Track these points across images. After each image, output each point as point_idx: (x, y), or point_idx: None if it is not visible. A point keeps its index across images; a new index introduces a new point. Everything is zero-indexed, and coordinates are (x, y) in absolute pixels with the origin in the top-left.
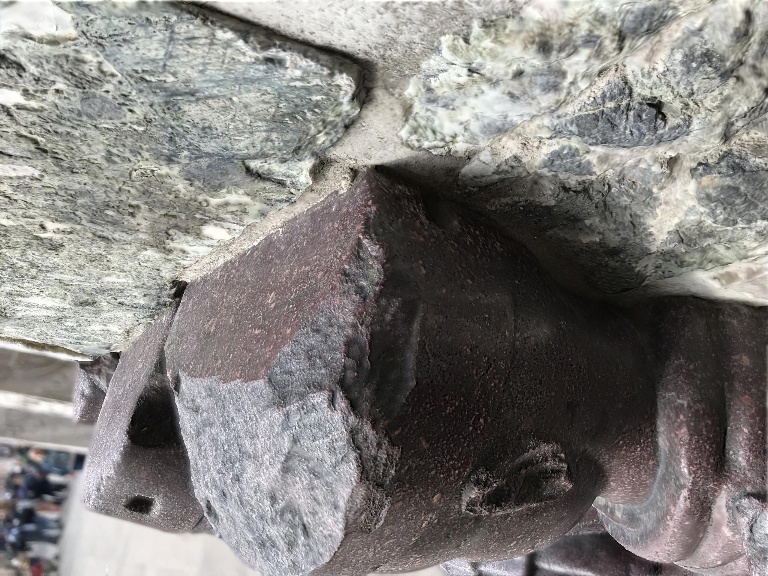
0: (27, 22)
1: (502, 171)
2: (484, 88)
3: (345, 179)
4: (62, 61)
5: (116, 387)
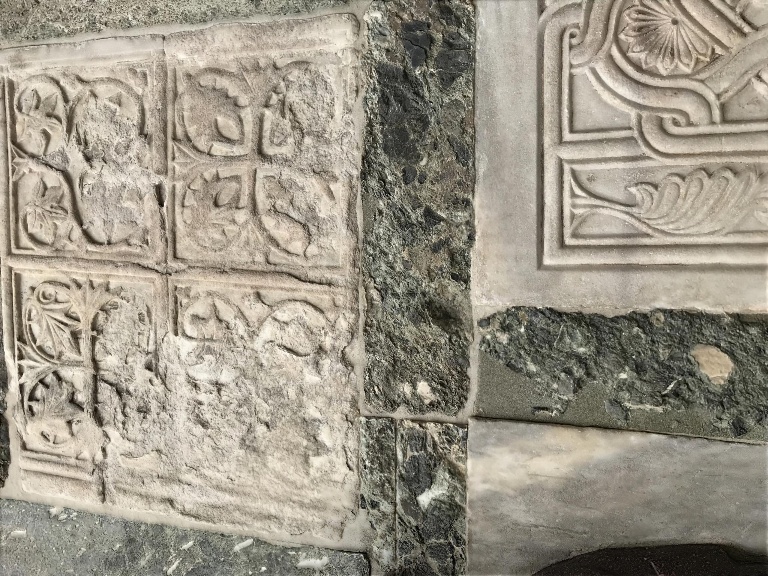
0: (324, 563)
1: (400, 570)
2: (383, 551)
3: None
4: (328, 568)
5: None
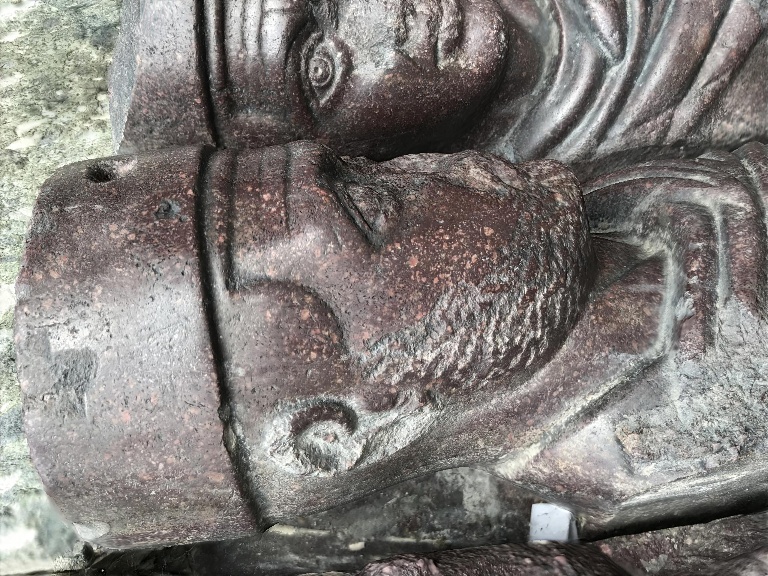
0: None
1: None
2: None
3: None
4: (36, 12)
5: None
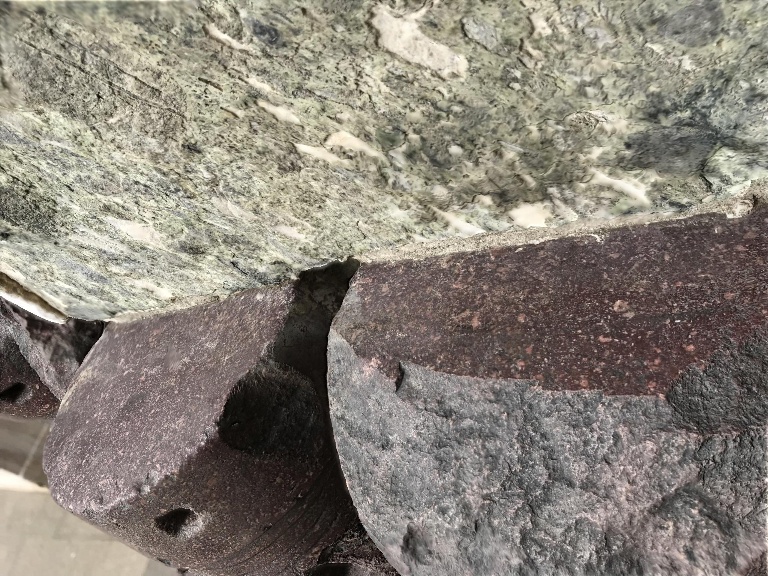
0: None
1: None
2: None
3: (746, 204)
4: None
5: (127, 364)
